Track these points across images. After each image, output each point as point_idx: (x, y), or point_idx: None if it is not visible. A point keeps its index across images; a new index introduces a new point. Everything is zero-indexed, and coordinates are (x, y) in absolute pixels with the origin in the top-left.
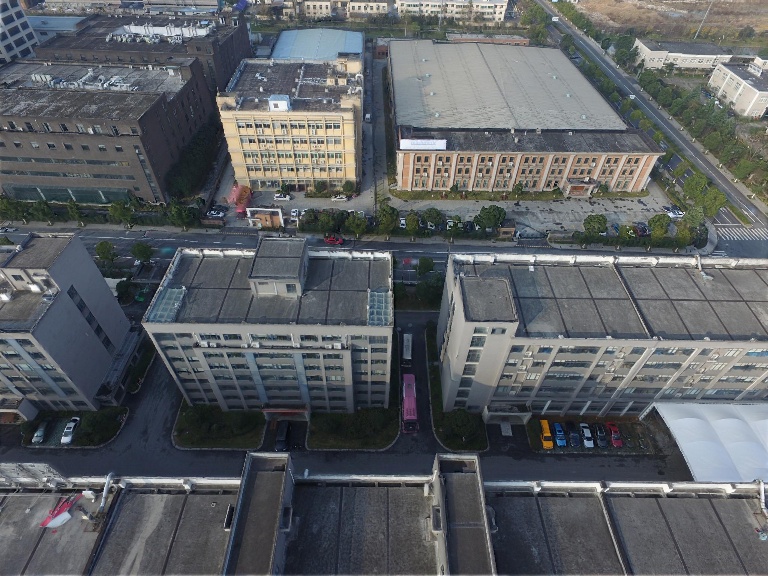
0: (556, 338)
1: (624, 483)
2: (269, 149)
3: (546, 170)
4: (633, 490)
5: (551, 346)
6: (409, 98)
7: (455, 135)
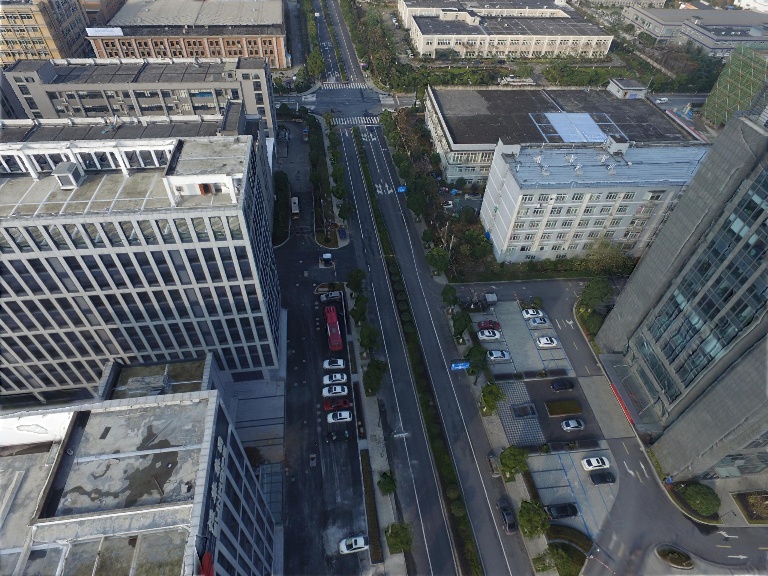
0: (66, 83)
1: (45, 119)
2: None
3: (208, 52)
4: (55, 125)
5: (72, 93)
6: (128, 13)
7: (142, 30)
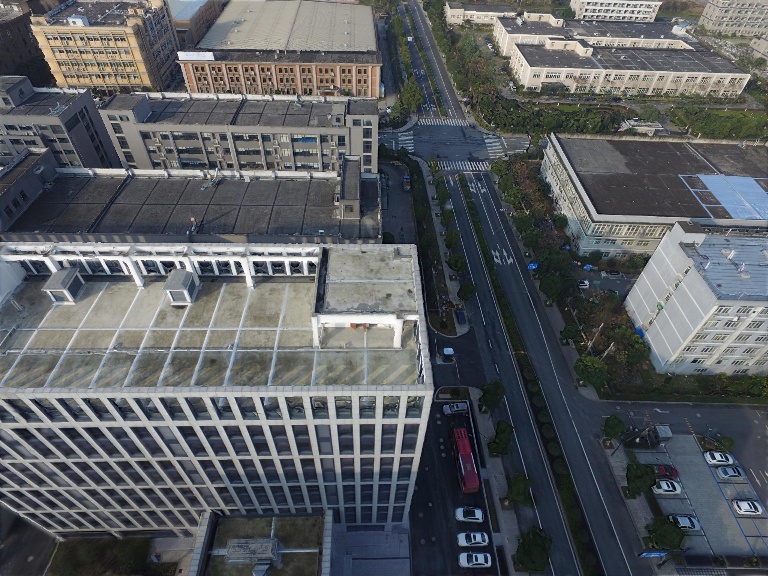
0: None
1: None
2: (76, 58)
3: (298, 79)
4: (150, 176)
5: (167, 133)
6: (217, 34)
7: (232, 54)
